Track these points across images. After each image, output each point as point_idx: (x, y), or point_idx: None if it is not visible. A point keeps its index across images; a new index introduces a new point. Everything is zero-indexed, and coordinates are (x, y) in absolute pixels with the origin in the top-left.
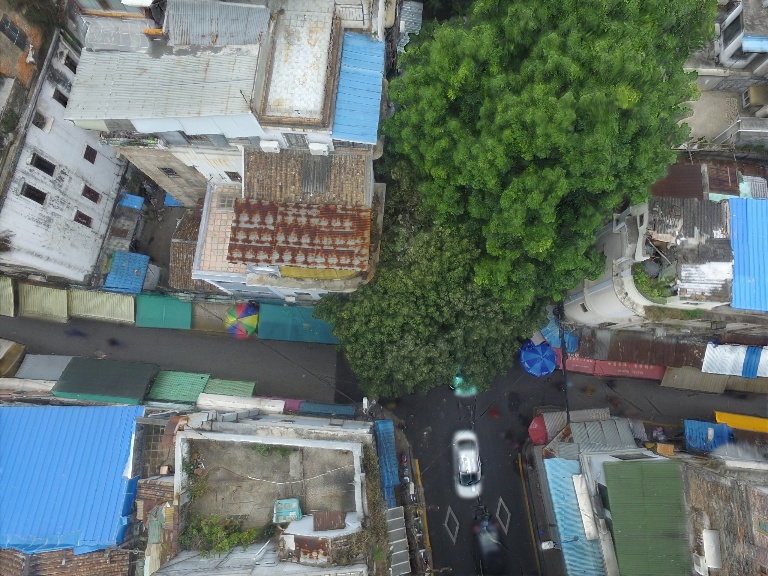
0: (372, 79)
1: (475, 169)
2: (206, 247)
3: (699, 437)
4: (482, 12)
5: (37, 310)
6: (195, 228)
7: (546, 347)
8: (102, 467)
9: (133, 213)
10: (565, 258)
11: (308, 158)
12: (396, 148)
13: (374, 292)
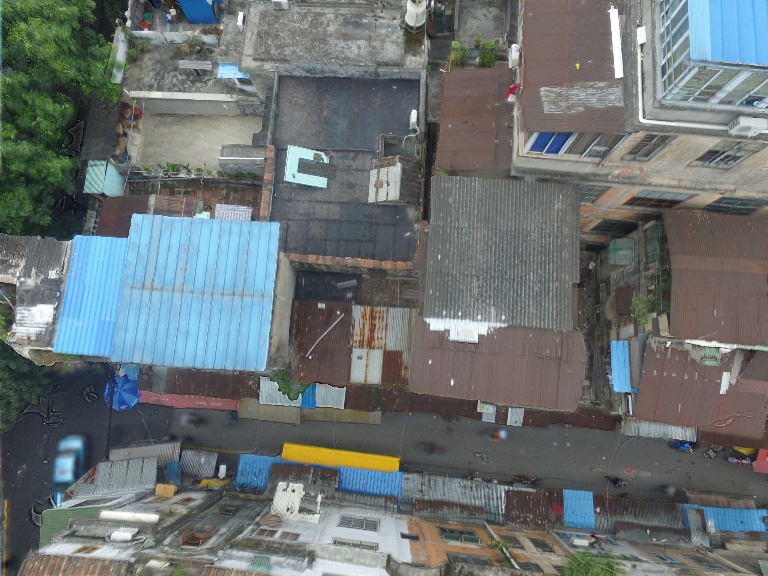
0: None
1: None
2: None
3: (252, 472)
4: None
5: None
6: None
7: None
8: None
9: None
10: None
11: None
12: None
13: None
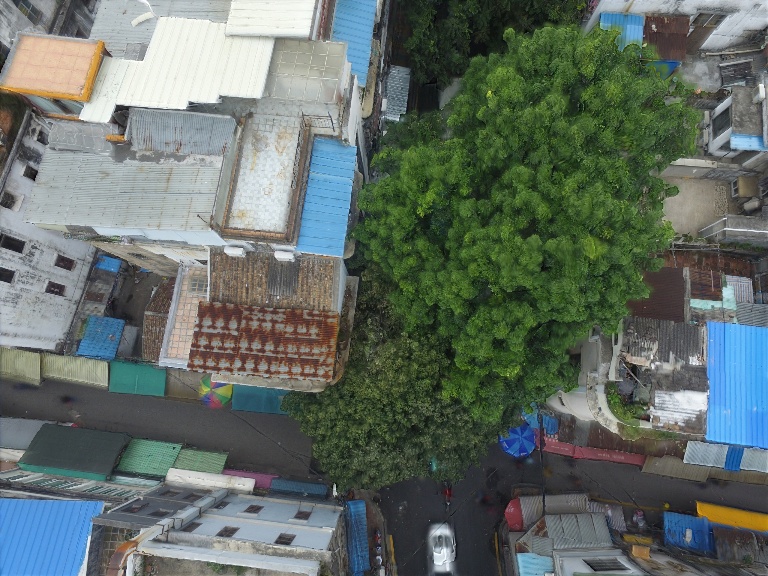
0: (341, 187)
1: (440, 296)
2: (175, 333)
3: (678, 530)
4: (455, 124)
5: (10, 371)
6: (169, 299)
7: (526, 426)
8: (56, 569)
9: (110, 276)
10: (536, 376)
11: (275, 261)
12: (365, 255)
13: (341, 394)
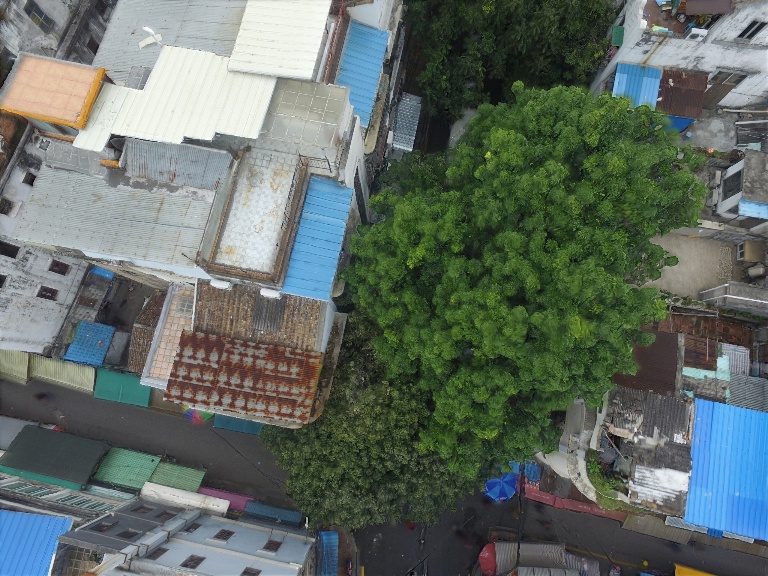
0: (334, 228)
1: (422, 354)
2: (159, 352)
3: None
4: (454, 176)
5: None
6: None
7: None
8: None
9: (104, 282)
10: (515, 437)
11: (262, 296)
12: (353, 299)
13: (318, 434)
